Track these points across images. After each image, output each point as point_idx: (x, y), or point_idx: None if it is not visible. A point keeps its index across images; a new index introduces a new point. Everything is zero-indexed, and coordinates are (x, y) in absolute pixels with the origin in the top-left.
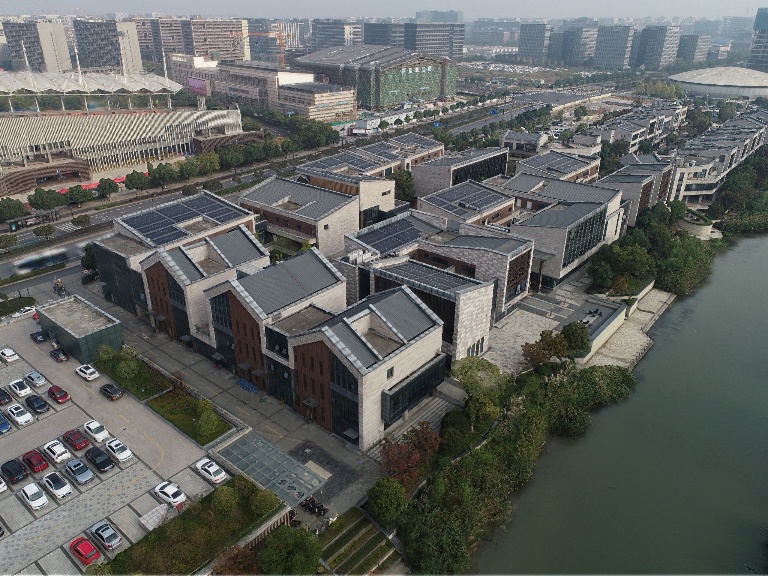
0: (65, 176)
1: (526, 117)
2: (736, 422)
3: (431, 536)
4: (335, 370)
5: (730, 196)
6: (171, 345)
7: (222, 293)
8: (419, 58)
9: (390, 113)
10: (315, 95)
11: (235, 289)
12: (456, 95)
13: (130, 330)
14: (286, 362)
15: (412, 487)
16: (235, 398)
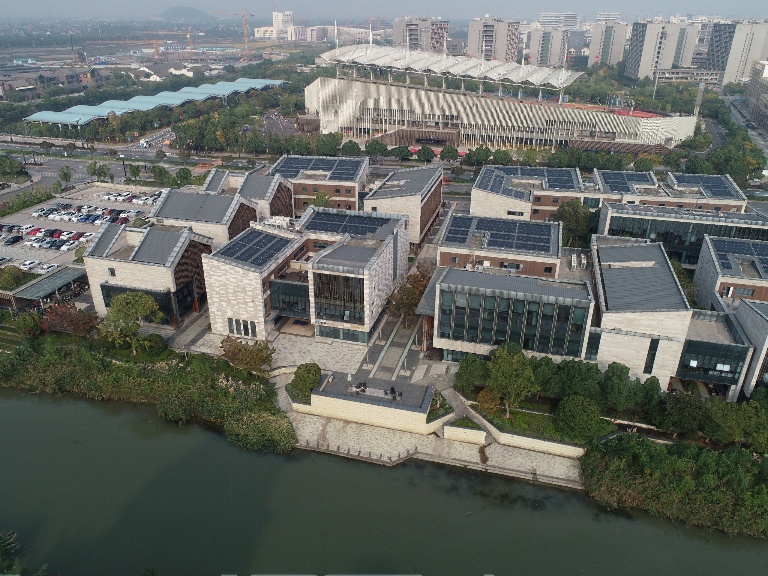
0: None
1: None
2: (216, 540)
3: None
4: None
5: None
6: None
7: None
8: None
9: None
10: None
11: None
12: None
13: None
14: None
15: None
16: None
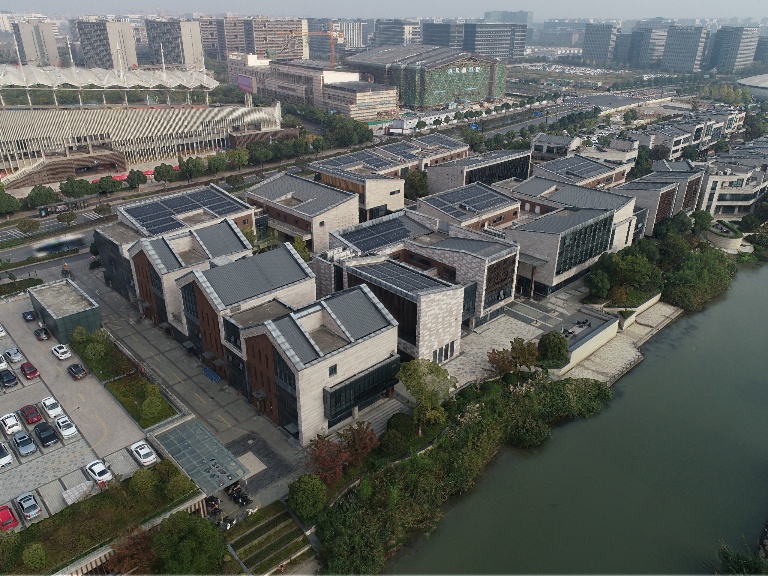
0: (104, 167)
1: (570, 120)
2: (710, 447)
3: (344, 536)
4: (277, 364)
5: (766, 208)
6: (153, 331)
7: (189, 283)
8: (467, 58)
9: (430, 113)
10: (357, 94)
11: (198, 279)
12: (506, 96)
13: (120, 315)
14: (240, 353)
15: (343, 486)
16: (197, 386)
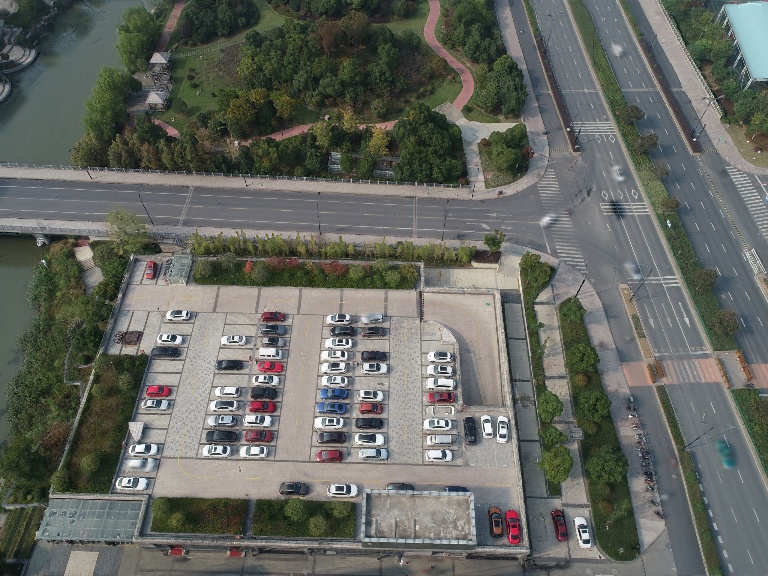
0: None
1: None
2: None
3: None
4: None
5: None
6: None
7: None
8: None
9: None
10: None
11: None
12: None
13: None
14: None
15: None
16: None
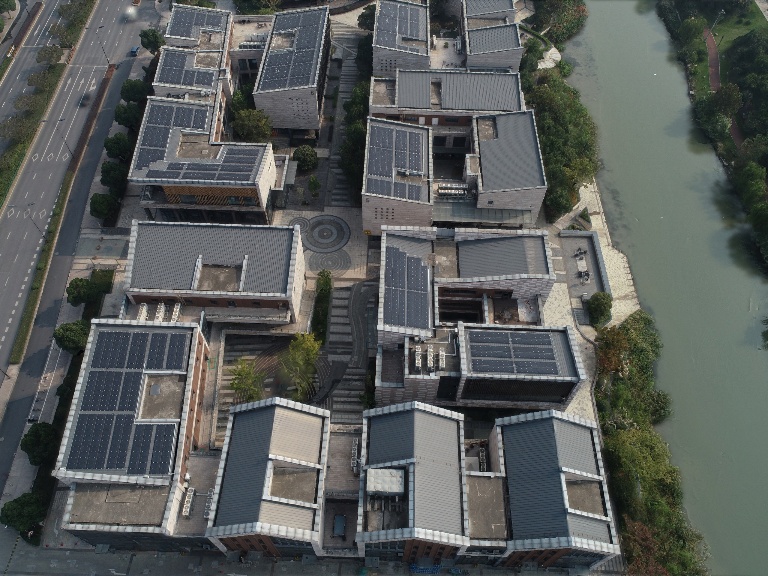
0: None
1: None
2: (733, 326)
3: None
4: None
5: (554, 3)
6: (283, 568)
7: None
8: None
9: None
10: None
11: (426, 539)
12: None
13: None
14: None
15: None
16: None
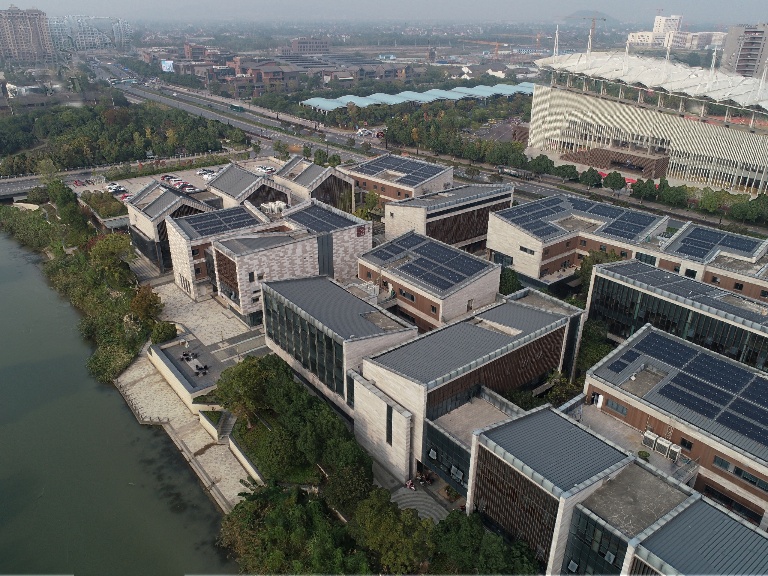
0: None
1: None
2: None
3: None
4: None
5: None
6: None
7: None
8: None
9: None
10: None
11: None
12: None
13: None
14: None
15: None
16: None
